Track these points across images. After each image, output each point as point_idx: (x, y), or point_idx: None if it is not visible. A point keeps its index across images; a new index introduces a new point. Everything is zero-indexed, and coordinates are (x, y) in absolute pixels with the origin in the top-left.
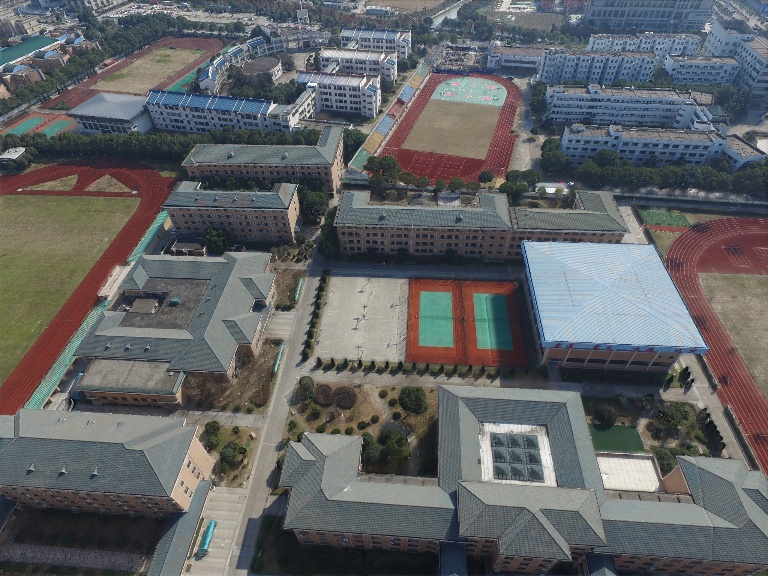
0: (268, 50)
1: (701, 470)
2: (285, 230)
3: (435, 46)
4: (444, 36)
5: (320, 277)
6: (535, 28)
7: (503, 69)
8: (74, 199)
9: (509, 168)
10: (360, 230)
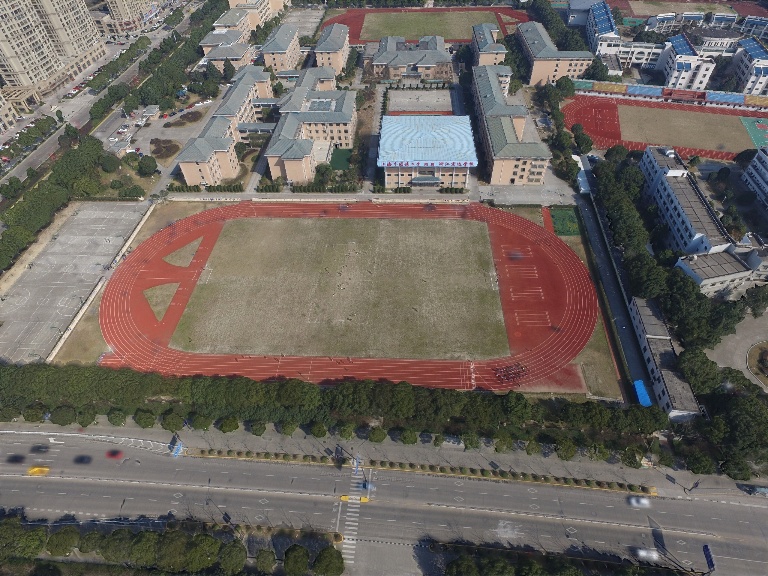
0: (765, 35)
1: (305, 139)
2: None
3: None
4: None
5: None
6: None
7: None
8: None
9: None
10: None
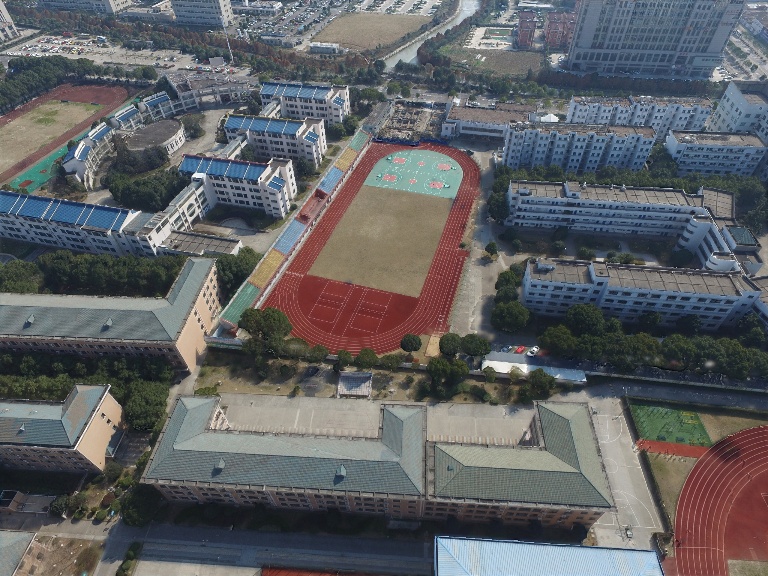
0: (175, 107)
1: None
2: (85, 462)
3: (380, 104)
4: (393, 89)
5: (121, 562)
6: (508, 73)
7: (462, 137)
8: None
9: (450, 315)
10: (185, 486)
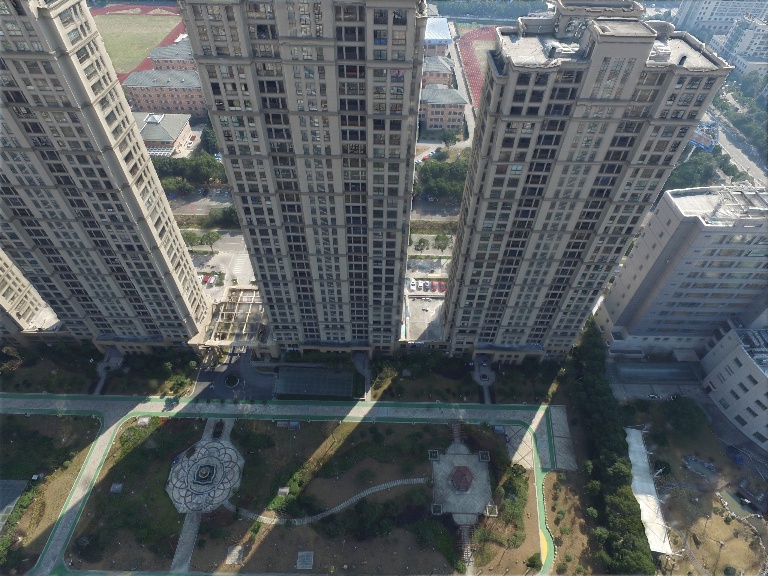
0: None
1: None
2: None
3: None
4: None
5: None
6: None
7: None
8: (143, 16)
9: None
10: None
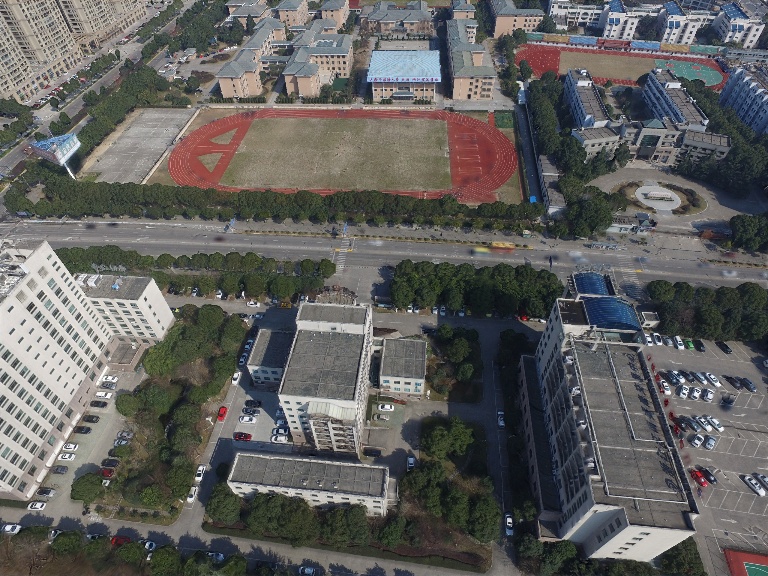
0: (693, 3)
1: None
2: None
3: None
4: None
5: None
6: None
7: None
8: None
9: None
10: None
